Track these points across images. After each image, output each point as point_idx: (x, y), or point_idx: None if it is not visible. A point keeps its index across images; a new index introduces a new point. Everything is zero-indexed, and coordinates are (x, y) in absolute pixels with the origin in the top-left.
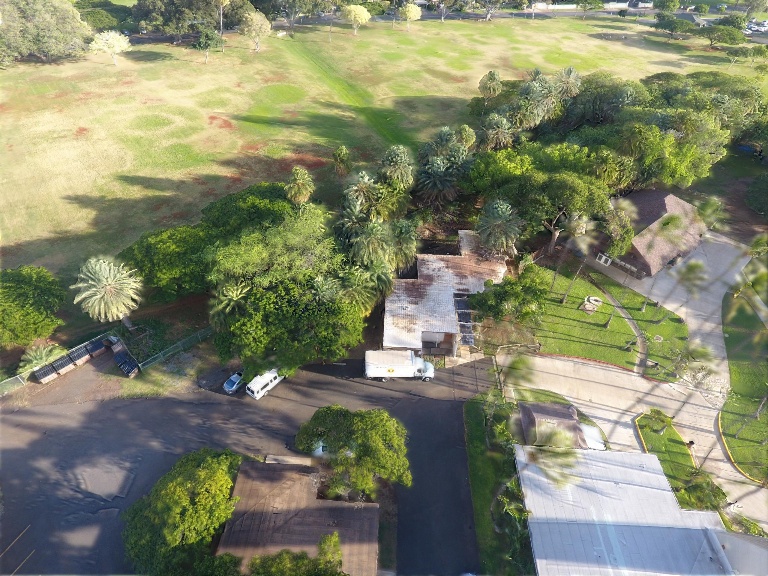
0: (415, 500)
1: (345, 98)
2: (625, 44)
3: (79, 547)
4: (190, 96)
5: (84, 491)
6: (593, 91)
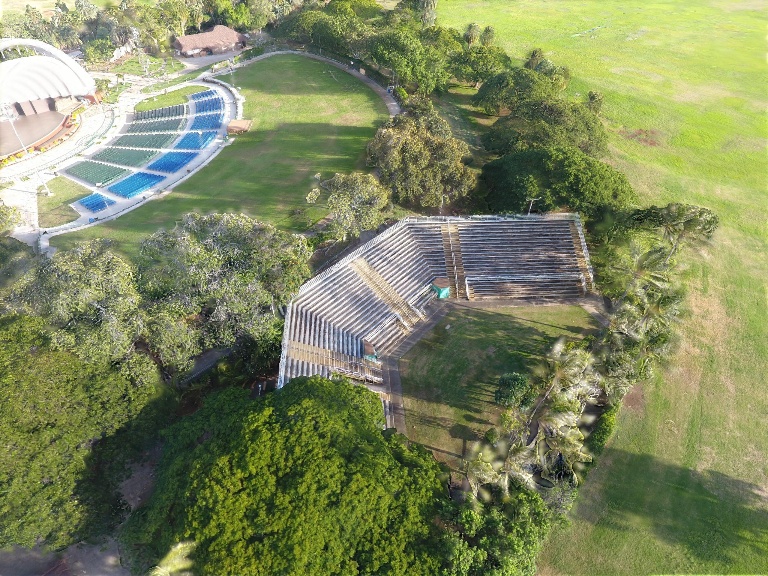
0: None
1: None
2: None
3: None
4: (41, 4)
5: None
6: None
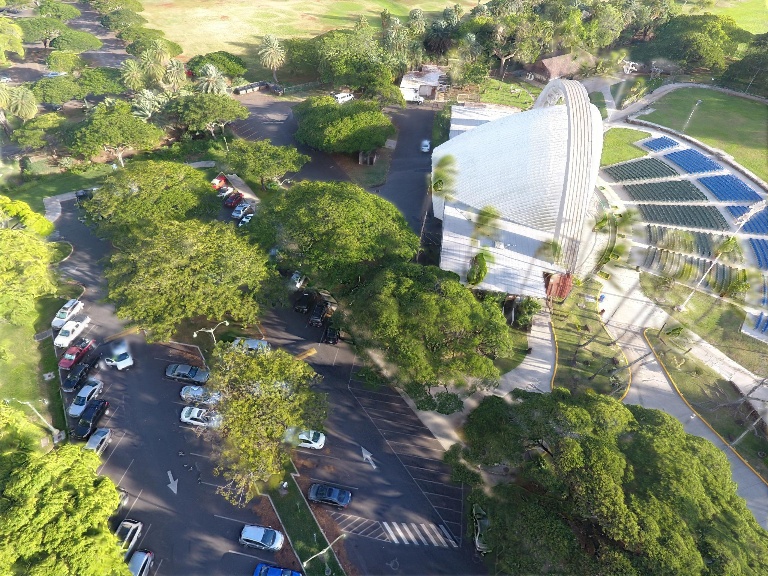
0: (408, 129)
1: (390, 11)
2: None
3: (270, 128)
4: (287, 5)
5: (268, 118)
6: (555, 2)
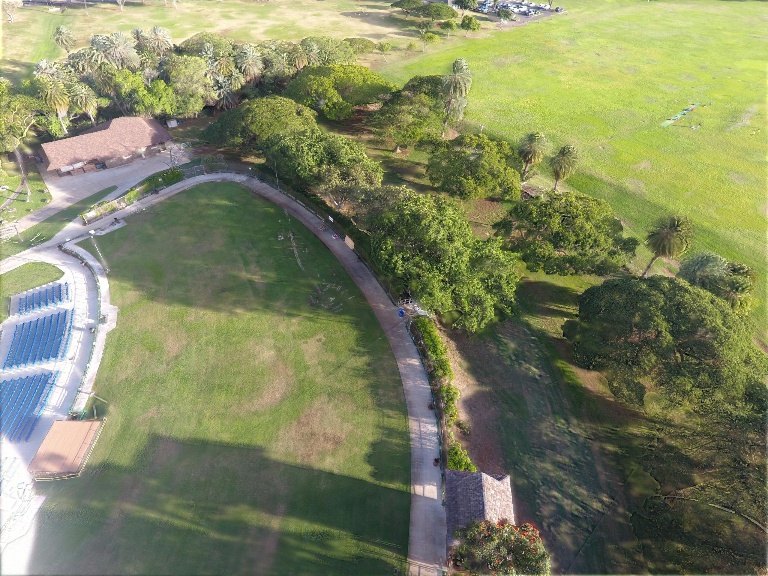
0: None
1: (34, 58)
2: (362, 20)
3: None
4: None
5: None
6: (191, 48)
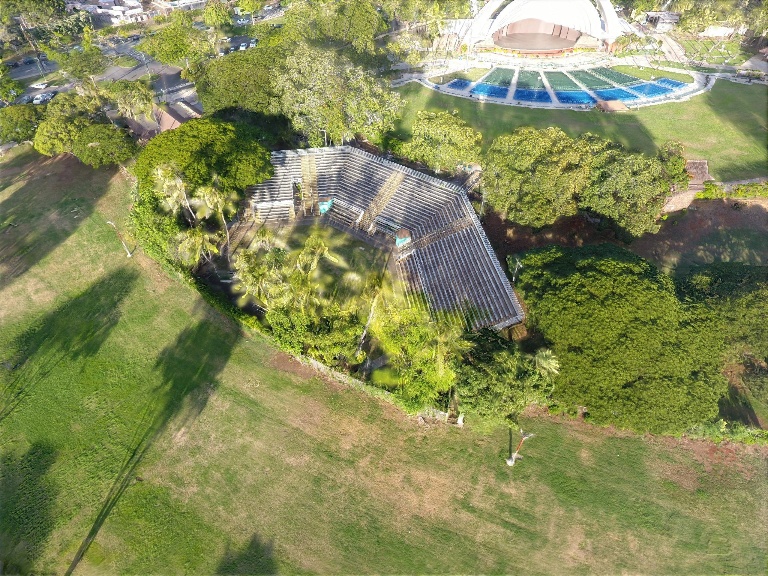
0: None
1: None
2: None
3: None
4: None
5: None
6: None
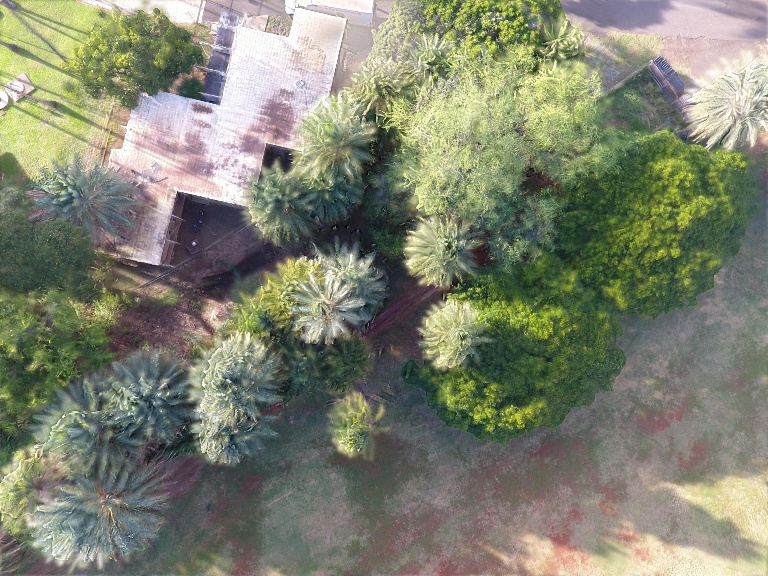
0: None
1: None
2: None
3: None
4: None
5: None
6: None
